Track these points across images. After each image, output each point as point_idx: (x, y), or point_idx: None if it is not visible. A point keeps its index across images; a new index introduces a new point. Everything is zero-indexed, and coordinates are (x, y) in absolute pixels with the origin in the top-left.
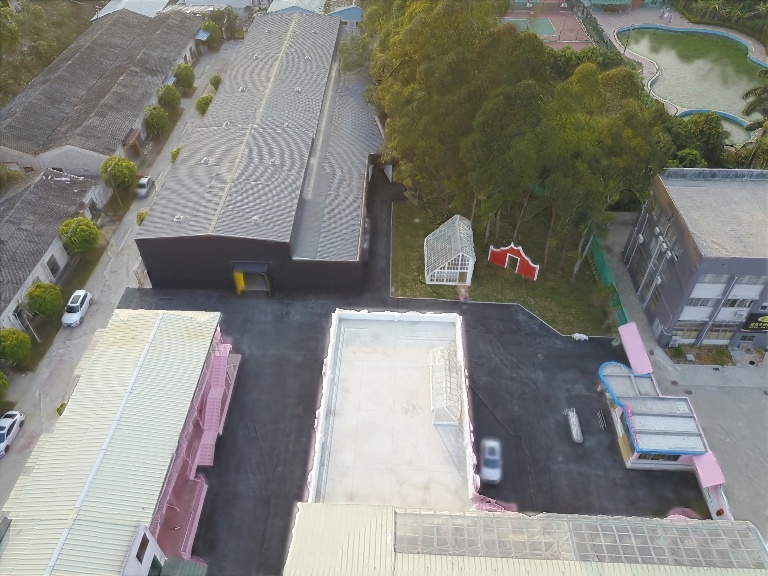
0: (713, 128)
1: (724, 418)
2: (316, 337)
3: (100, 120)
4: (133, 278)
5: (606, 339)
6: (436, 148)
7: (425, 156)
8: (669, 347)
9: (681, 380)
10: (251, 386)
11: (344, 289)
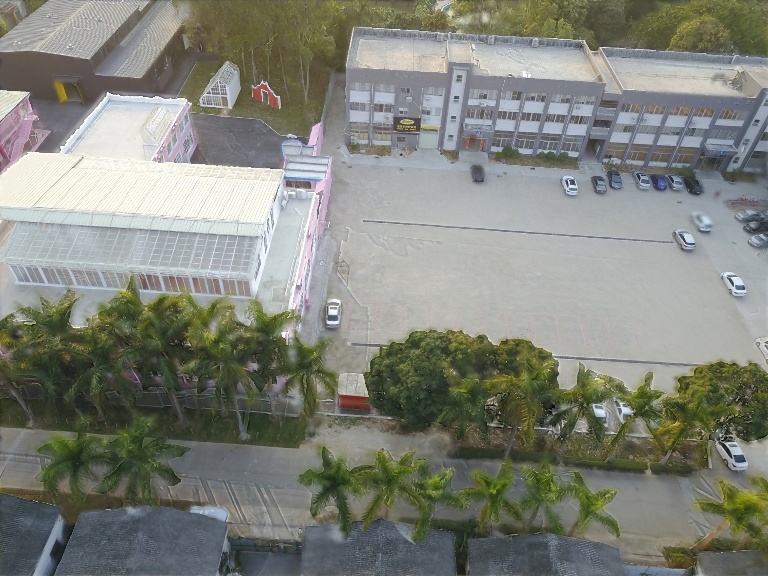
0: (439, 20)
1: (365, 179)
2: None
3: None
4: None
5: (309, 138)
6: (194, 0)
7: (194, 10)
8: (351, 145)
9: (349, 161)
10: (52, 146)
11: None
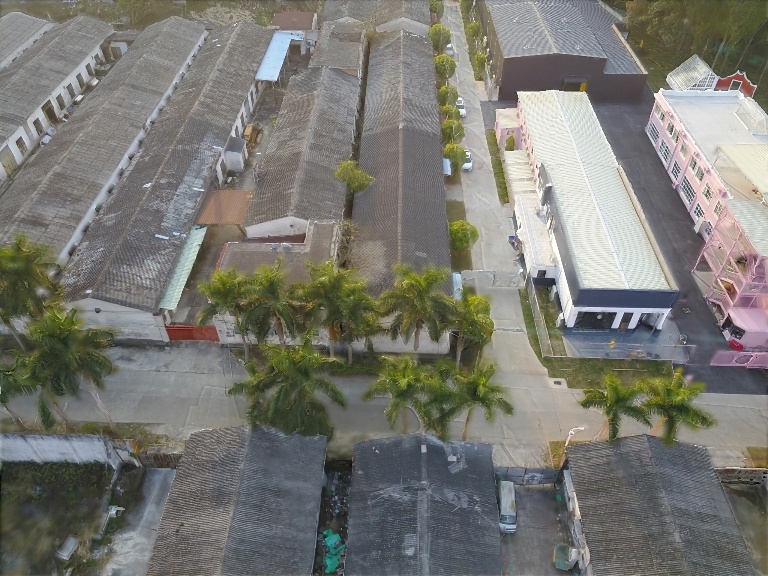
0: None
1: None
2: (626, 122)
3: (410, 5)
4: (480, 96)
5: None
6: None
7: (688, 6)
8: None
9: None
10: None
11: (630, 99)
